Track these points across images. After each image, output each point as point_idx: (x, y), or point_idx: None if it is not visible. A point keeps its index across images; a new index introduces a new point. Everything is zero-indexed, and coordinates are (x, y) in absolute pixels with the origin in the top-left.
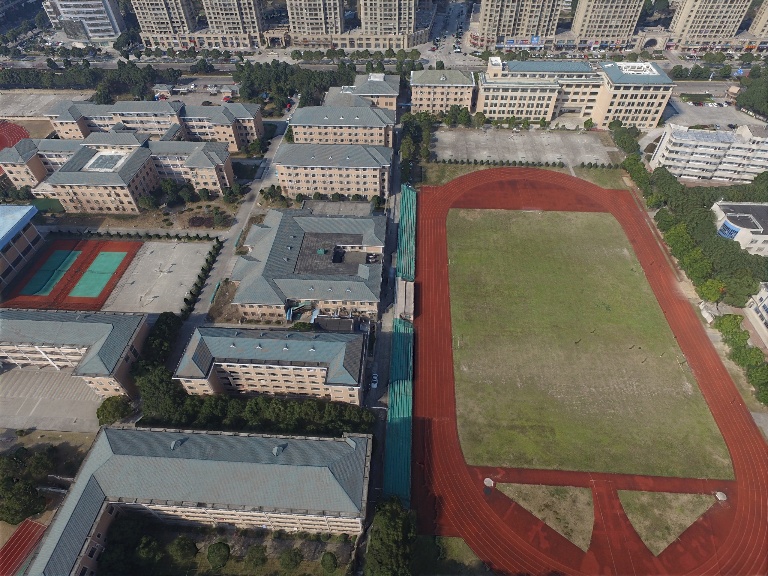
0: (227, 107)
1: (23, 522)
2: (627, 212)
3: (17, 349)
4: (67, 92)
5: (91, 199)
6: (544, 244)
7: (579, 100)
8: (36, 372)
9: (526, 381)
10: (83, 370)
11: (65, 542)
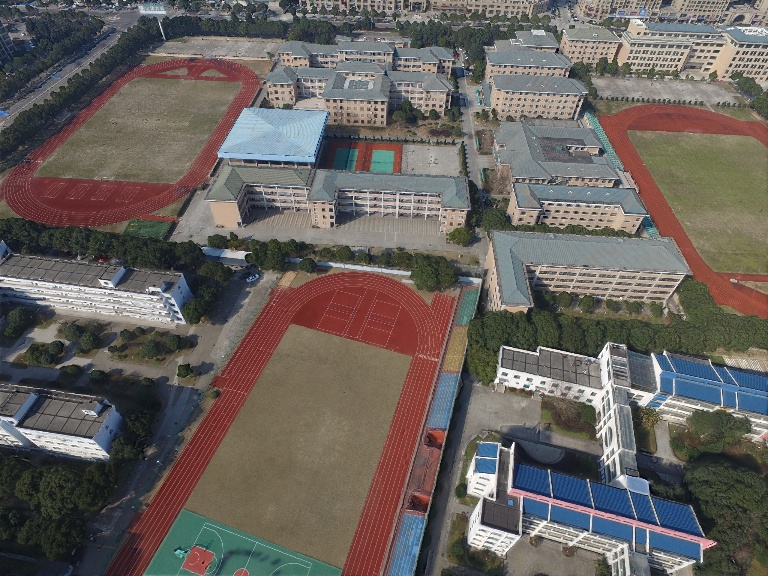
0: (431, 50)
1: (435, 294)
2: (764, 136)
3: (380, 197)
4: (258, 40)
5: (352, 113)
6: (711, 154)
7: (703, 57)
8: (381, 219)
9: (734, 231)
10: (448, 205)
11: (518, 278)
